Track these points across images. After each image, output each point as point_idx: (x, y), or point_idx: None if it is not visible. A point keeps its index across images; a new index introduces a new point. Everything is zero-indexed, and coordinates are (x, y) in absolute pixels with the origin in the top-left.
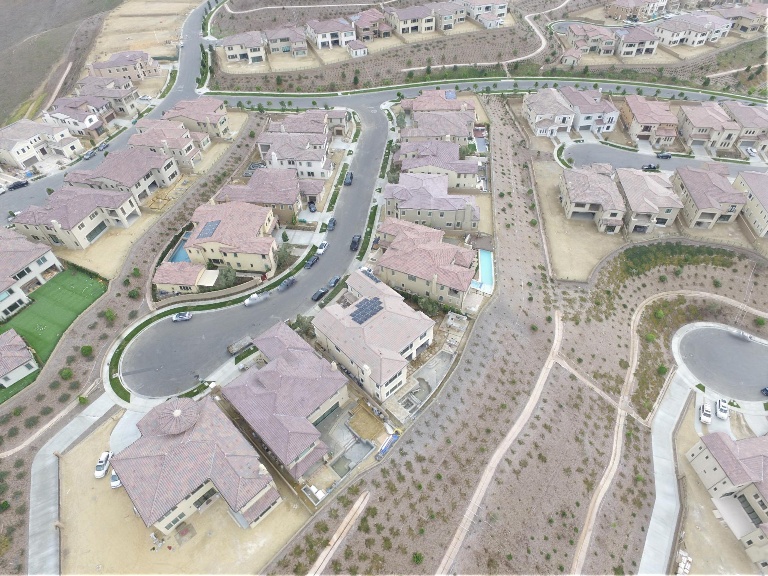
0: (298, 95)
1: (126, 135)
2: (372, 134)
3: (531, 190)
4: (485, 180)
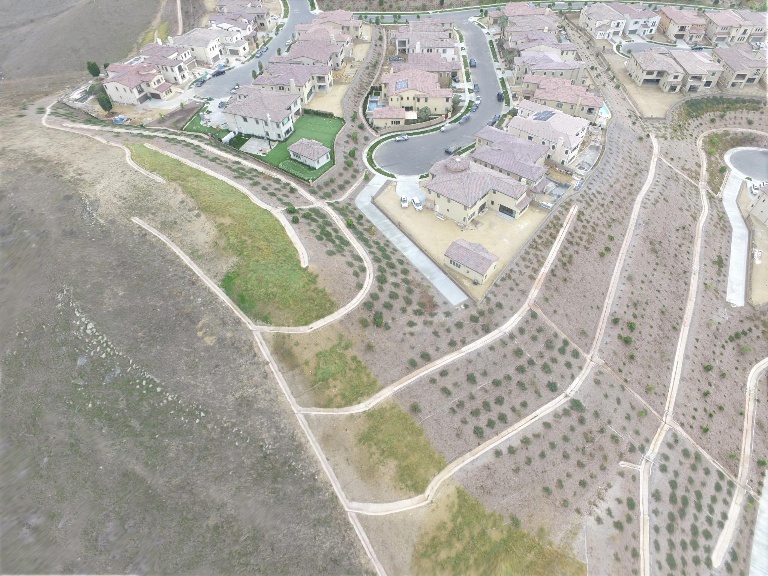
0: (398, 13)
1: (276, 42)
2: (473, 37)
3: (609, 68)
4: (577, 60)
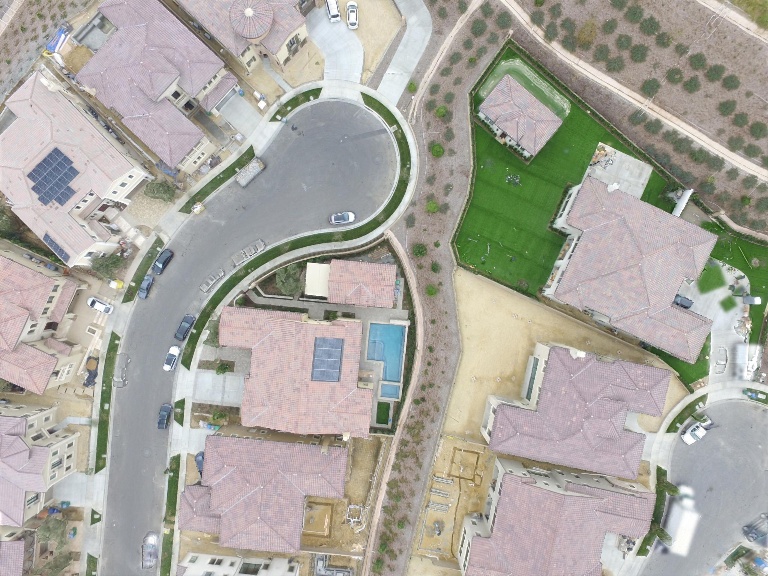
0: None
1: None
2: None
3: None
4: None
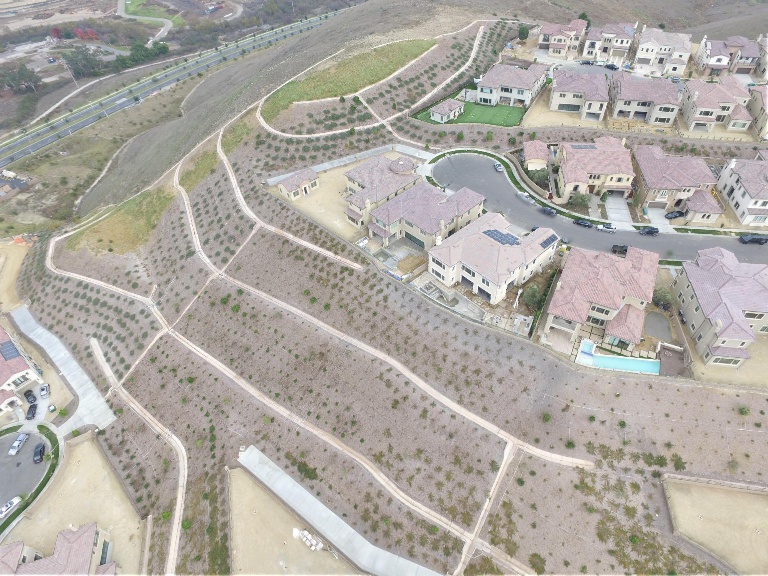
0: None
1: None
2: None
3: None
4: None
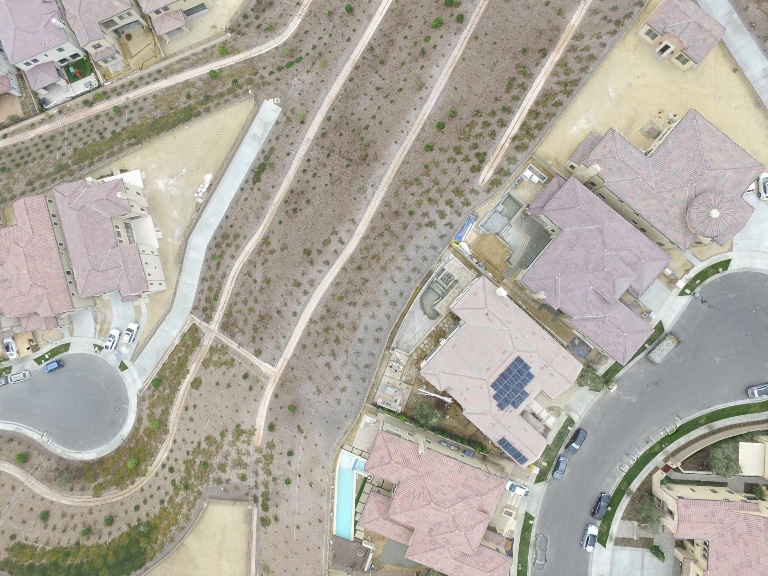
0: None
1: None
2: None
3: None
4: None
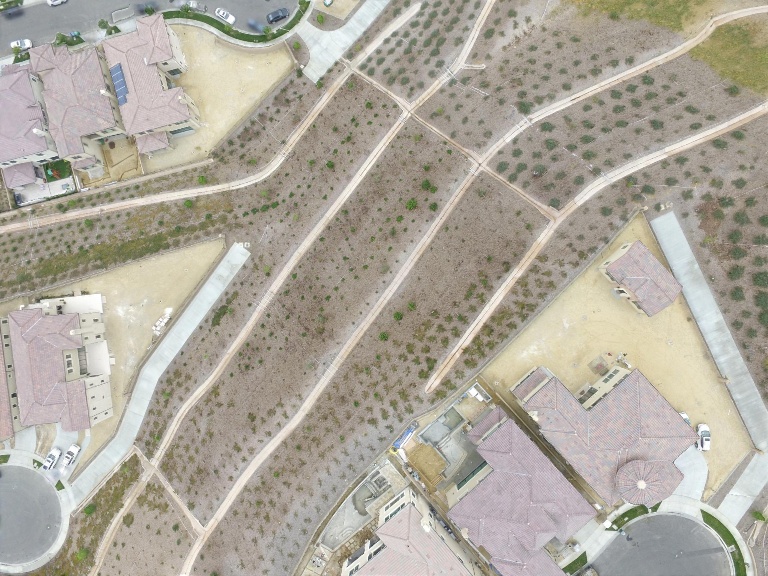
0: None
1: None
2: None
3: None
4: None
